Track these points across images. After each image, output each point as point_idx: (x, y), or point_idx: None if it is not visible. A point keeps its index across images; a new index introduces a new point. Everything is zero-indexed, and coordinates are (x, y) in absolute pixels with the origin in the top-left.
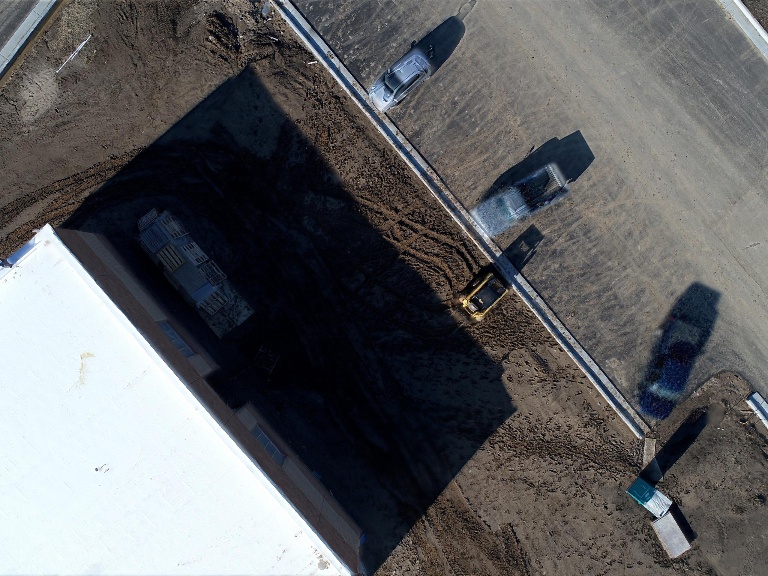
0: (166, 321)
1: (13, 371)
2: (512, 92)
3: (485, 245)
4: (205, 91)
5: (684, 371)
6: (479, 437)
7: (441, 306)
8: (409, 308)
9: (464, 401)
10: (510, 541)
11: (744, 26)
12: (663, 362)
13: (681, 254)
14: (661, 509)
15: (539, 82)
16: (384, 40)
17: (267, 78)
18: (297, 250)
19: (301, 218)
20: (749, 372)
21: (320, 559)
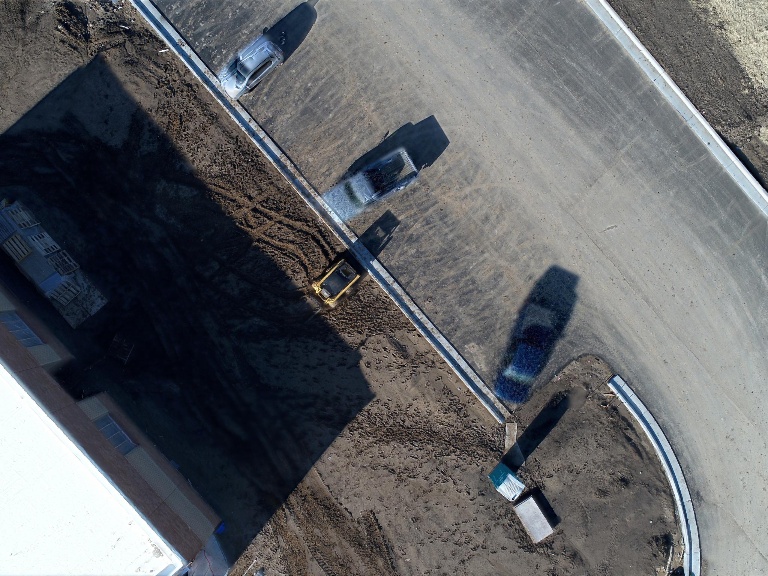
0: (14, 311)
1: None
2: (365, 78)
3: (340, 231)
4: (55, 80)
5: (544, 355)
6: (338, 424)
7: (297, 293)
8: (264, 295)
9: (322, 388)
10: (372, 528)
11: (596, 8)
12: (523, 346)
13: (538, 238)
14: (513, 493)
15: (392, 67)
16: (236, 27)
17: (117, 67)
18: (150, 239)
19: (153, 207)
20: (610, 355)
21: (155, 547)
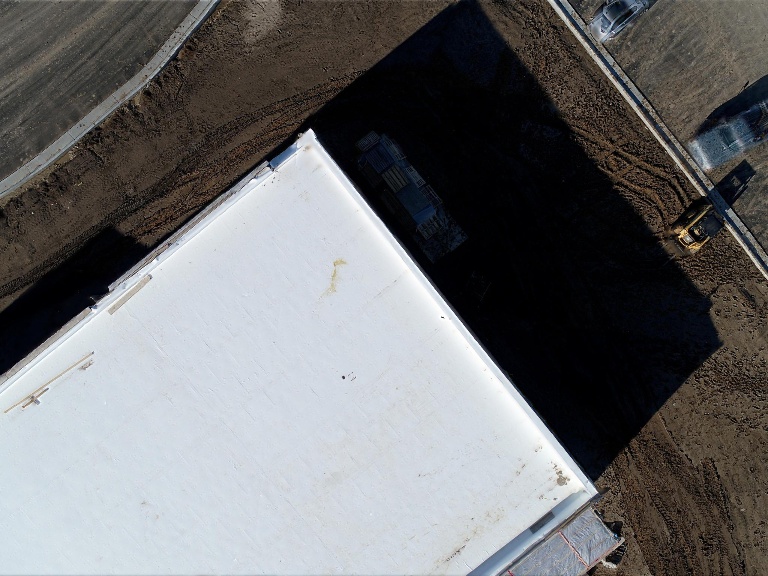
0: None
1: (267, 276)
2: (729, 27)
3: (697, 179)
4: (426, 16)
5: None
6: (685, 370)
7: (652, 238)
8: (621, 239)
9: (671, 334)
10: (710, 476)
11: None
12: None
13: None
14: None
15: (756, 18)
16: None
17: (487, 5)
18: (512, 177)
19: (518, 145)
20: None
21: (559, 475)
